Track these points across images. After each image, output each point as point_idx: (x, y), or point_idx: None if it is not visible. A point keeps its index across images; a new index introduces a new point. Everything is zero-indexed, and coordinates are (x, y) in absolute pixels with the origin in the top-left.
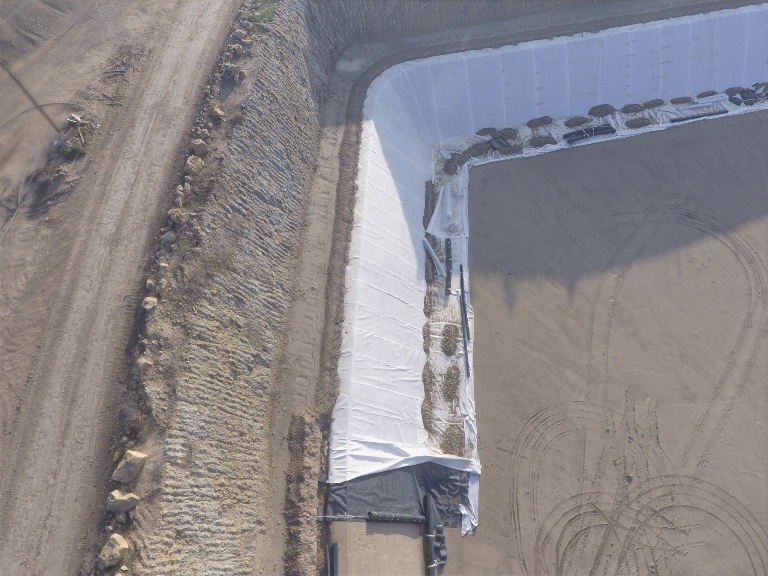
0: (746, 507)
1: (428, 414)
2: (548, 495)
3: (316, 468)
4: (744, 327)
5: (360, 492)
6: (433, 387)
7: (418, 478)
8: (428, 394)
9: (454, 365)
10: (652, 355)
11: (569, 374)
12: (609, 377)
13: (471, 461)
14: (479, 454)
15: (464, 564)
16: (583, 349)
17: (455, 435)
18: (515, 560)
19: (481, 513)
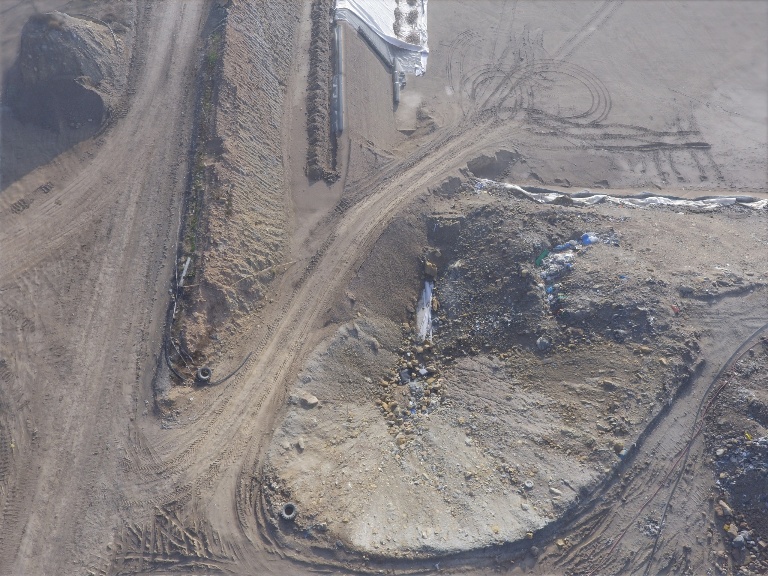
0: (593, 73)
1: (397, 28)
2: (470, 63)
3: (328, 3)
4: (607, 1)
5: (354, 19)
6: (401, 18)
7: (390, 50)
8: (397, 20)
9: (415, 9)
10: (544, 11)
11: (489, 16)
12: (514, 19)
13: (423, 47)
14: (428, 46)
15: (416, 86)
16: (499, 6)
17: (414, 36)
18: (447, 86)
19: (428, 68)
